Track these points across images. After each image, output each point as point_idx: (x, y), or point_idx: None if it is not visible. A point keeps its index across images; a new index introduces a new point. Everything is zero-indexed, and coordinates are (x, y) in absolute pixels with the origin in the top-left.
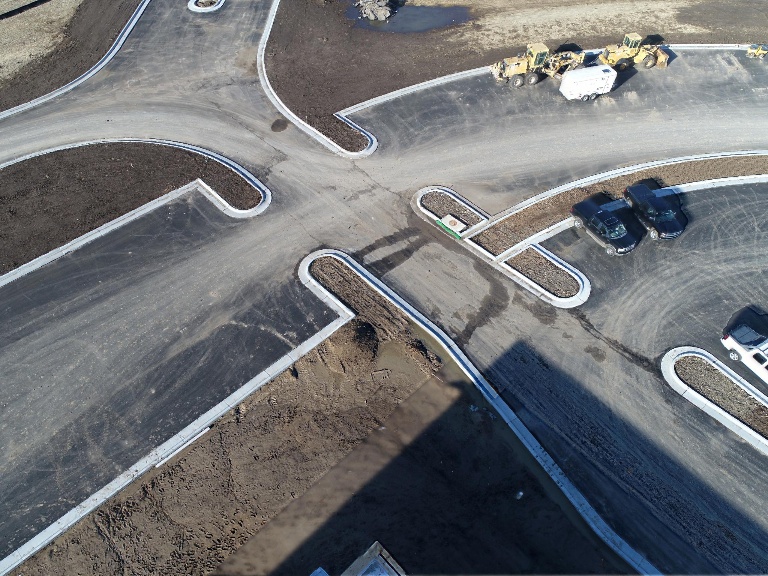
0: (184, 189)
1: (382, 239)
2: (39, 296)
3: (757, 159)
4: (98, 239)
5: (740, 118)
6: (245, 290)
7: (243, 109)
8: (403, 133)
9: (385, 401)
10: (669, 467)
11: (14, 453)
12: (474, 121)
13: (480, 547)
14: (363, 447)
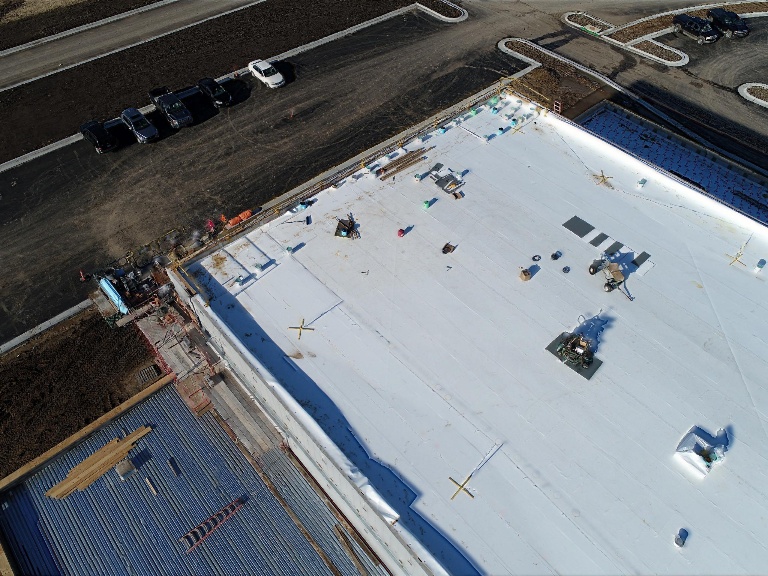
0: (409, 8)
1: (547, 34)
2: (341, 51)
3: None
4: (365, 28)
5: None
6: (468, 53)
7: None
8: None
9: (571, 98)
10: (746, 127)
11: (362, 110)
12: None
13: None
14: (564, 113)
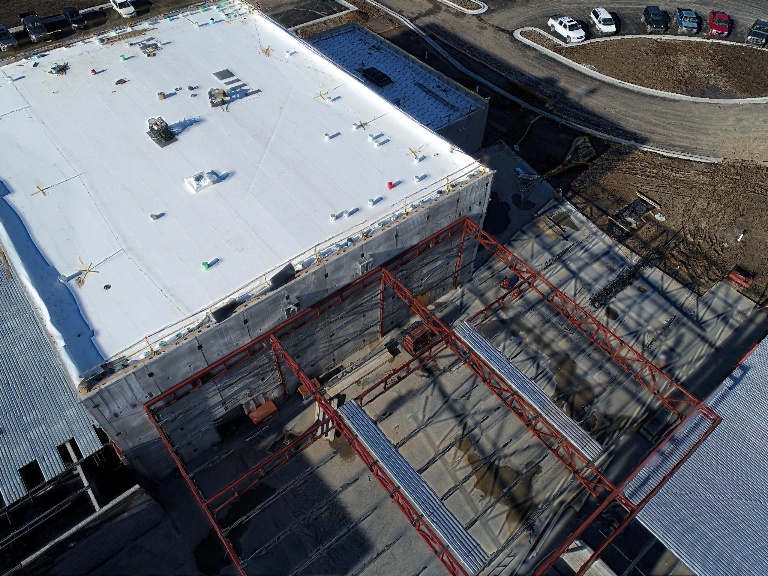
0: None
1: None
2: None
3: None
4: None
5: None
6: None
7: None
8: None
9: None
10: (503, 57)
11: None
12: None
13: None
14: None
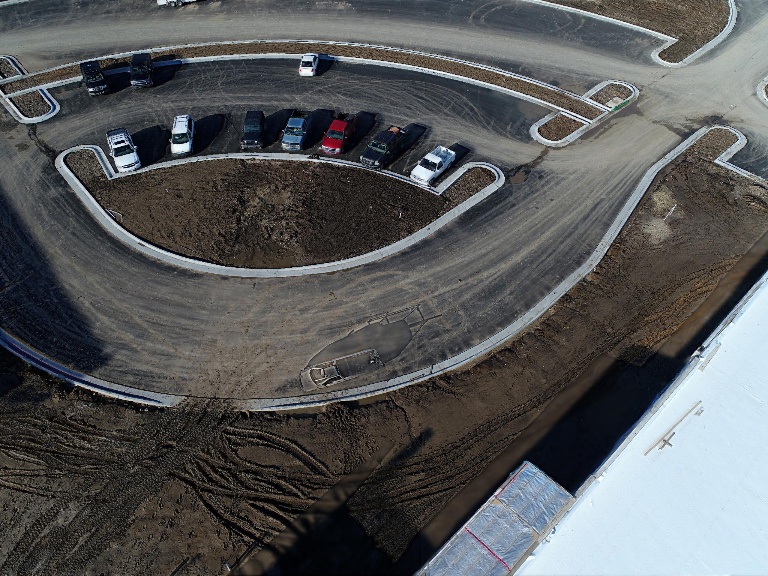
0: None
1: None
2: None
3: (268, 45)
4: None
5: (285, 20)
6: None
7: None
8: (10, 23)
9: None
10: (6, 202)
11: None
12: (73, 17)
13: None
14: None
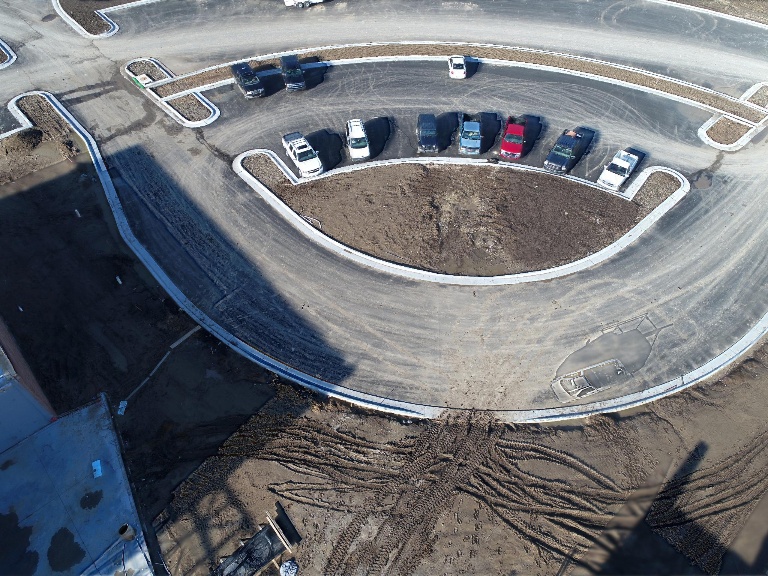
0: None
1: (84, 87)
2: None
3: (407, 46)
4: None
5: (417, 21)
6: None
7: (27, 7)
8: (142, 25)
9: (24, 170)
10: (197, 208)
11: None
12: (204, 18)
13: (36, 237)
14: None
